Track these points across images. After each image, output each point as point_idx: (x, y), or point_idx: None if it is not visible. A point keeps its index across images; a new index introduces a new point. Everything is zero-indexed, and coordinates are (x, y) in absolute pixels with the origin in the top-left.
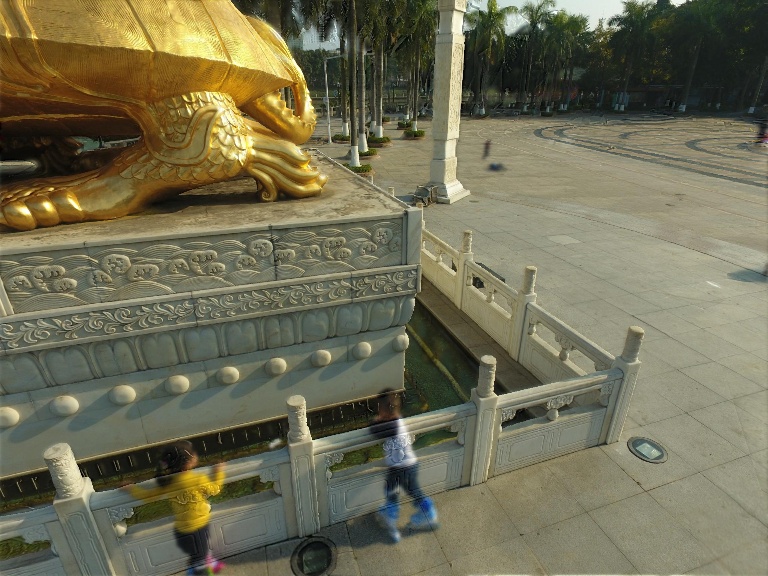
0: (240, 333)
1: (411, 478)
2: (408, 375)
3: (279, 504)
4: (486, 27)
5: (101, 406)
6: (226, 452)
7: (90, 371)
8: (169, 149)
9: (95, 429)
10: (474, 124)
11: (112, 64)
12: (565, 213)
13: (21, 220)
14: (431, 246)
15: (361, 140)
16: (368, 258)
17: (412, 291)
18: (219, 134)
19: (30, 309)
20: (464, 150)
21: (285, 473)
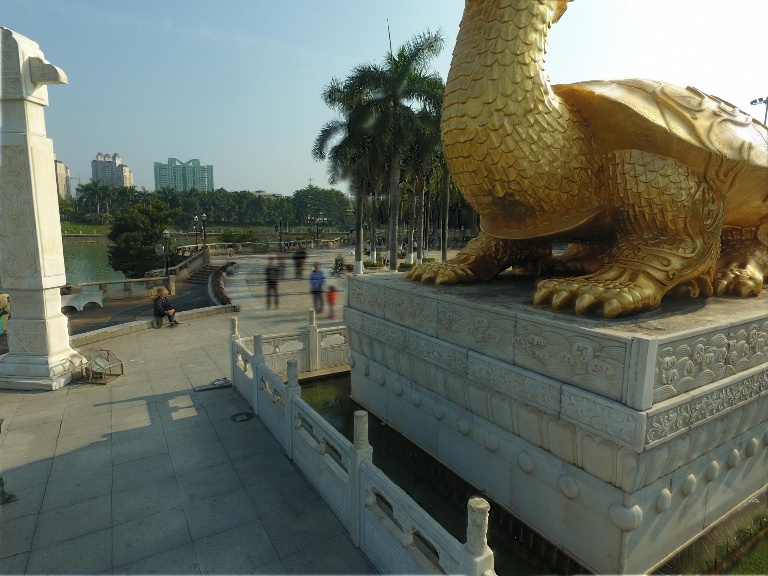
0: None
1: None
2: None
3: None
4: None
5: None
6: None
7: None
8: None
9: None
10: None
11: None
12: None
13: None
14: None
15: None
16: None
17: None
18: None
19: None
20: None
21: None
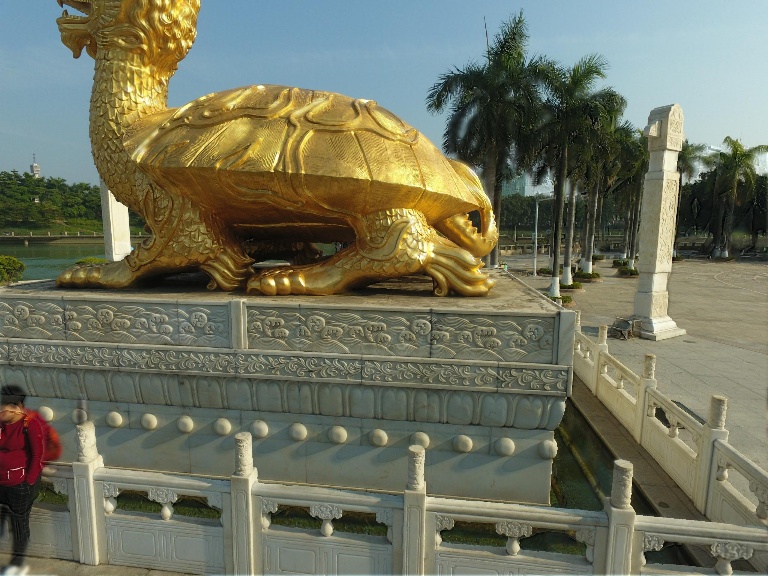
0: (393, 399)
1: None
2: (560, 496)
3: (389, 552)
4: (729, 168)
5: (282, 437)
6: None
7: (281, 405)
8: (370, 248)
9: (273, 456)
10: (712, 267)
11: (344, 188)
12: None
13: (269, 288)
14: None
15: (565, 273)
16: (517, 351)
17: (561, 393)
18: (408, 239)
19: (257, 347)
20: (691, 292)
21: (398, 520)
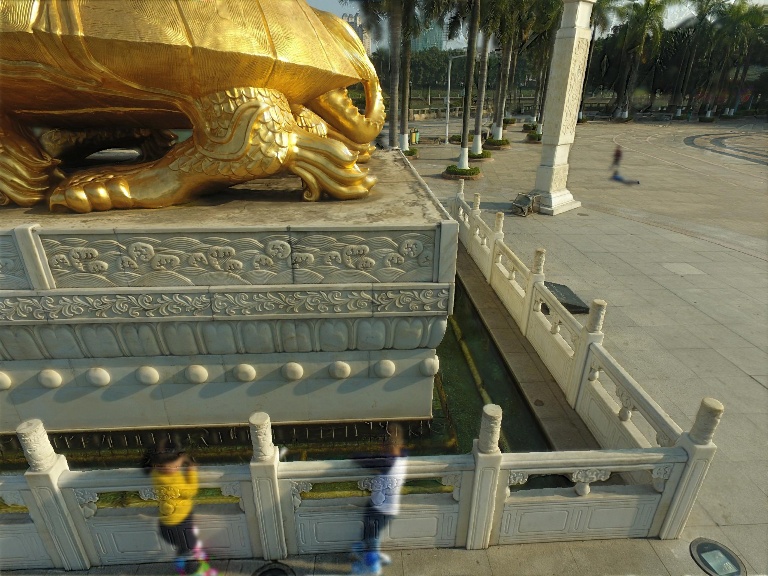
0: (255, 333)
1: (392, 525)
2: (444, 401)
3: (242, 521)
4: (640, 21)
5: (129, 382)
6: (241, 447)
7: (119, 349)
8: (212, 144)
9: (124, 403)
10: (612, 128)
11: (153, 59)
12: (694, 237)
13: (78, 203)
14: None
15: (476, 142)
16: (393, 271)
17: (442, 312)
18: (260, 130)
19: (69, 285)
20: (591, 157)
21: (247, 491)
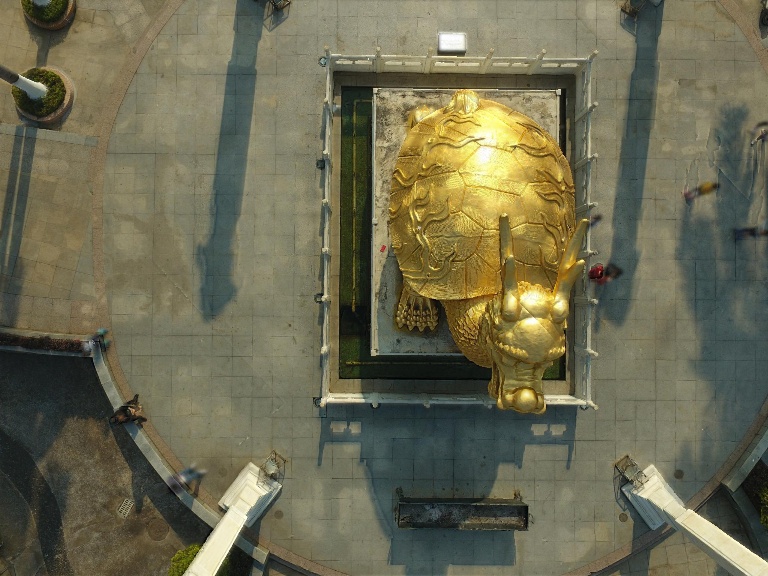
0: None
1: None
2: None
3: None
4: None
5: None
6: None
7: None
8: None
9: None
10: None
11: None
12: None
13: None
14: (392, 46)
15: None
16: None
17: None
18: None
19: None
20: None
21: None
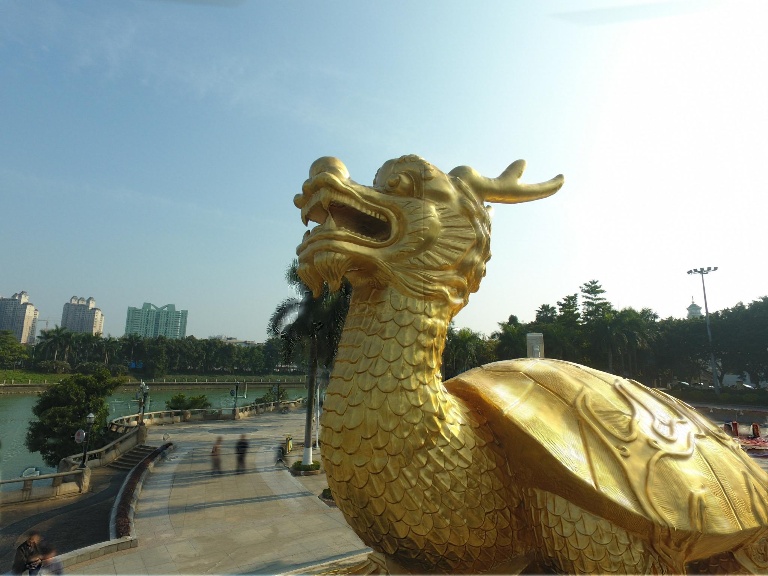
0: None
1: None
2: None
3: None
4: None
5: None
6: None
7: None
8: (760, 569)
9: None
10: None
11: None
12: None
13: None
14: None
15: None
16: None
17: None
18: None
19: None
20: None
21: None
